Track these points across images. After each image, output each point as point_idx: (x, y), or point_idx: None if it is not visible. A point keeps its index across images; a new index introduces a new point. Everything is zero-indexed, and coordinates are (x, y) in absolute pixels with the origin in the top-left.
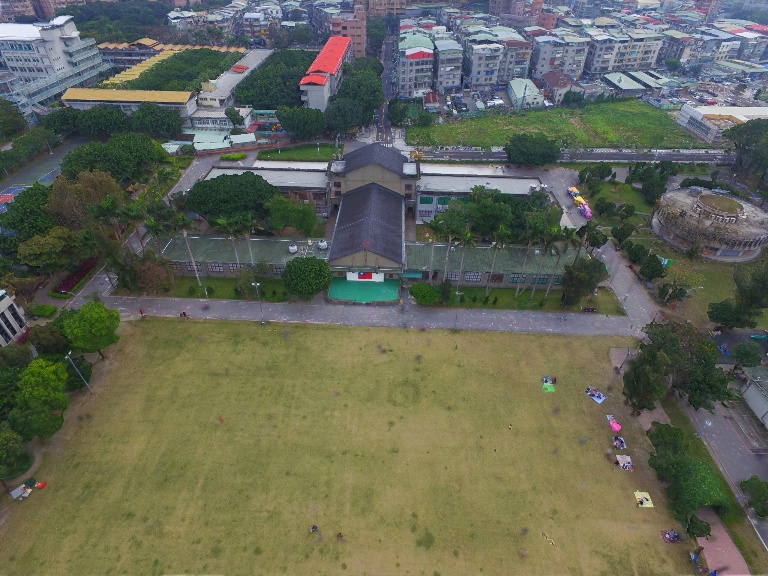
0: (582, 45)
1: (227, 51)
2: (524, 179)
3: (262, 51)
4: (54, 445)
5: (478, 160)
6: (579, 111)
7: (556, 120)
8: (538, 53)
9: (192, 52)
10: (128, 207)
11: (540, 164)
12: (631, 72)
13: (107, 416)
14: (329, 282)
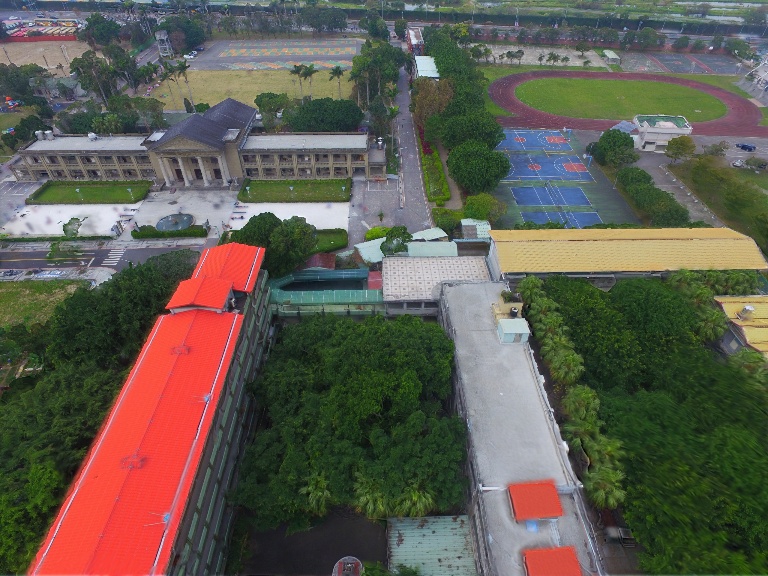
0: None
1: None
2: None
3: None
4: None
5: (11, 242)
6: None
7: None
8: None
9: None
10: (368, 62)
11: None
12: None
13: None
14: None
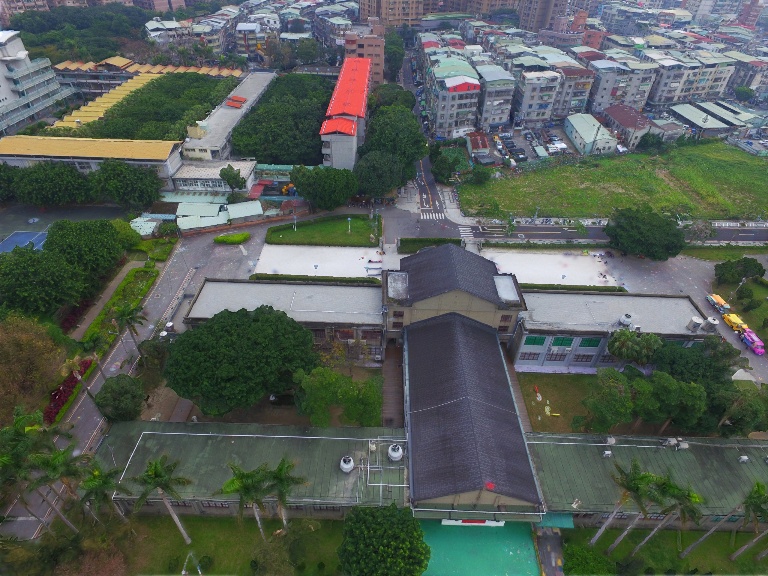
0: (649, 72)
1: (219, 75)
2: (667, 298)
3: (262, 74)
4: None
5: (566, 243)
6: (661, 159)
7: (641, 174)
8: (597, 82)
9: (175, 77)
10: (47, 456)
11: (663, 258)
12: (699, 103)
13: None
14: (426, 566)
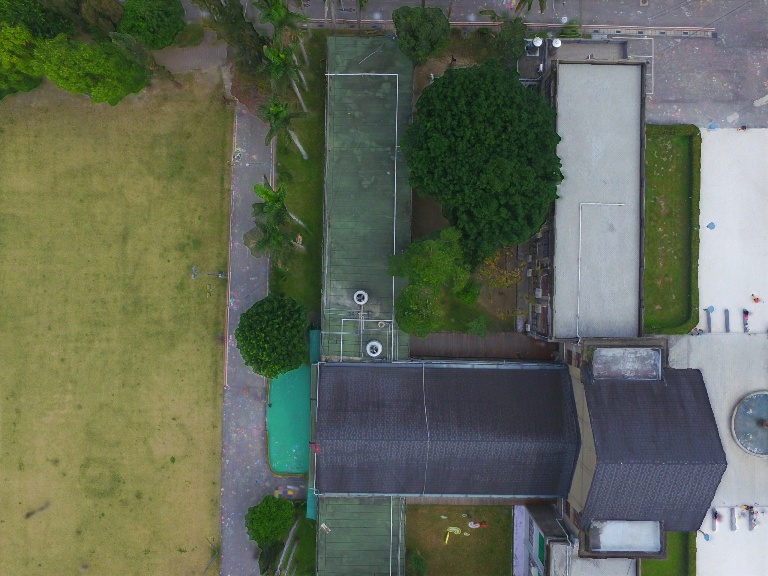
0: None
1: None
2: None
3: None
4: (25, 93)
5: None
6: None
7: None
8: None
9: None
10: (279, 0)
11: None
12: None
13: (61, 132)
14: None
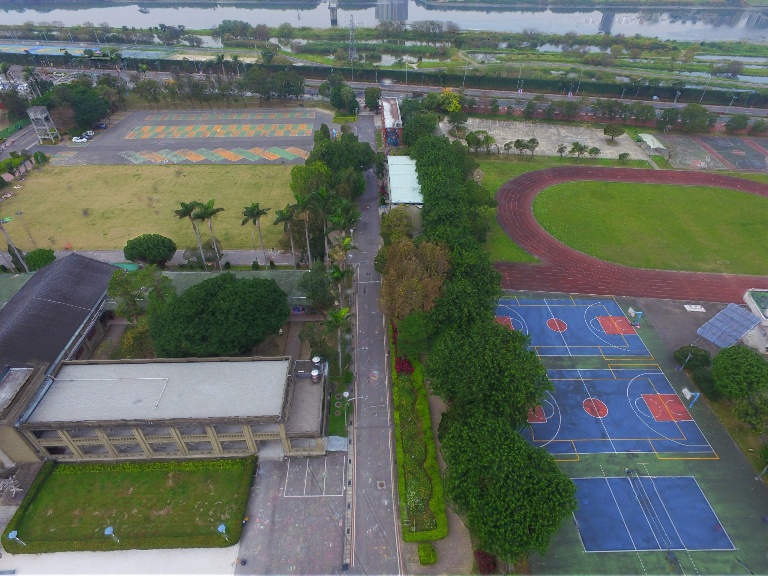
0: None
1: None
2: None
3: None
4: None
5: None
6: None
7: None
8: None
9: None
10: (305, 199)
11: None
12: None
13: None
14: None
